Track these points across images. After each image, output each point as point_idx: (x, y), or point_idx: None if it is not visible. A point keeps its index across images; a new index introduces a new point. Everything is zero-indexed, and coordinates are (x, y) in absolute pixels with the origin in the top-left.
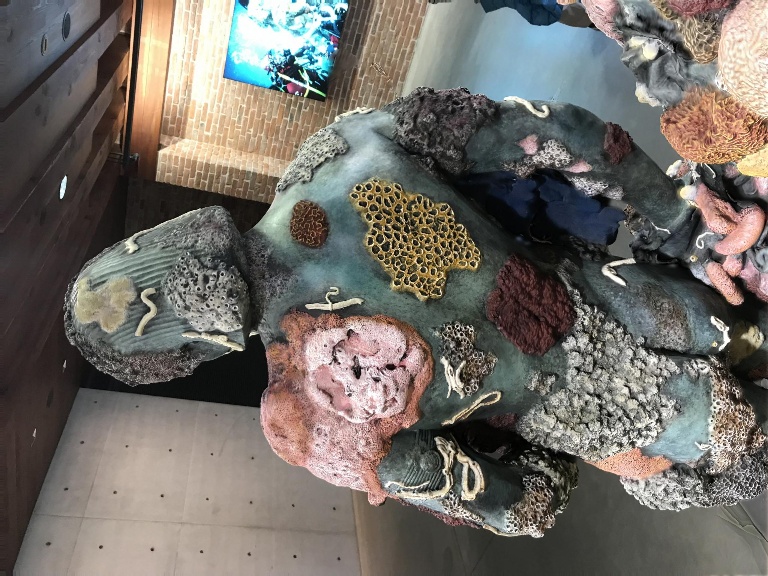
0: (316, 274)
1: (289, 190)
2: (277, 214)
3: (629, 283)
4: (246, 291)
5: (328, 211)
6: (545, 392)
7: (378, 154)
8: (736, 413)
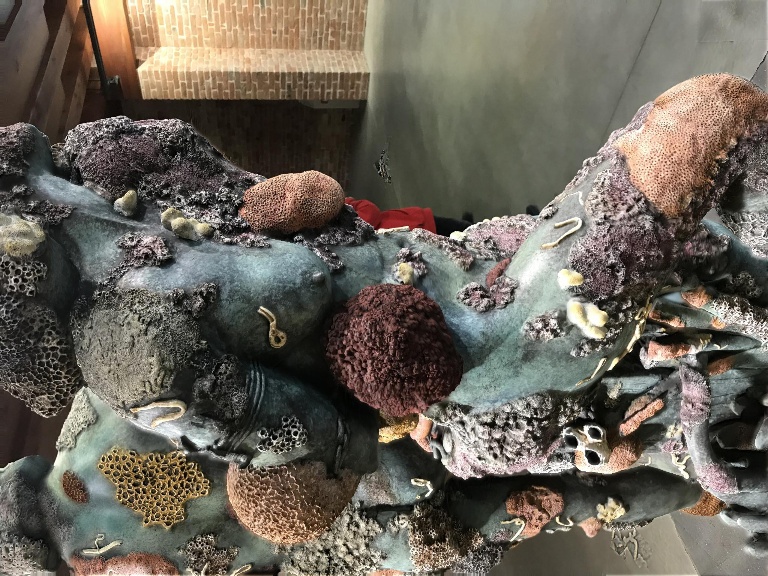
0: (89, 522)
1: (63, 453)
2: (58, 472)
3: None
4: (40, 546)
5: (86, 478)
6: (288, 553)
7: (118, 422)
8: (431, 551)
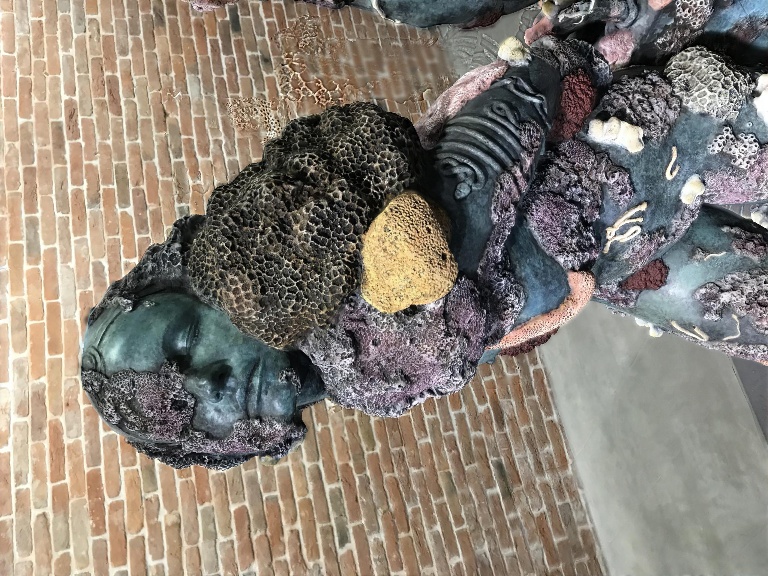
0: None
1: None
2: None
3: None
4: None
5: None
6: None
7: None
8: None
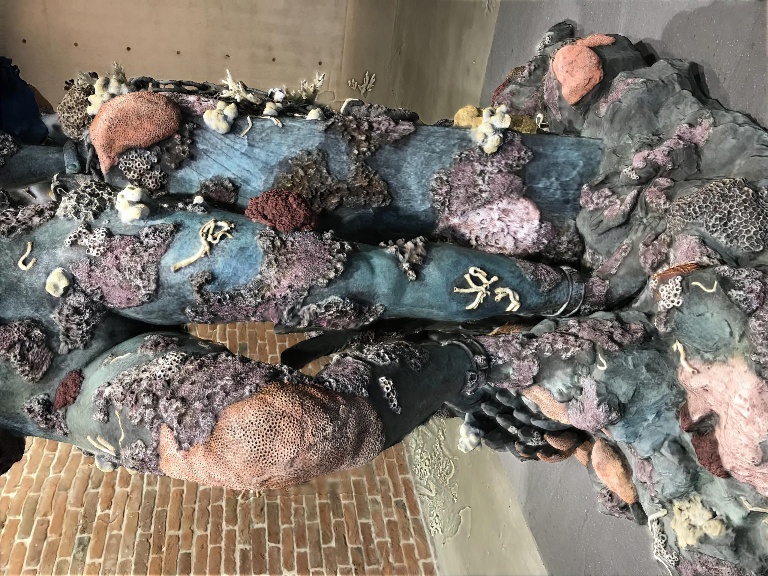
0: None
1: None
2: None
3: (38, 198)
4: None
5: None
6: None
7: None
8: None
